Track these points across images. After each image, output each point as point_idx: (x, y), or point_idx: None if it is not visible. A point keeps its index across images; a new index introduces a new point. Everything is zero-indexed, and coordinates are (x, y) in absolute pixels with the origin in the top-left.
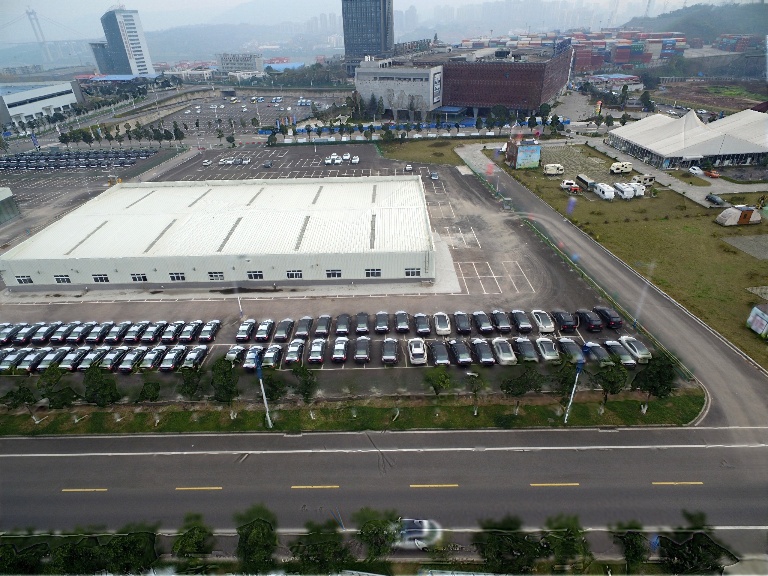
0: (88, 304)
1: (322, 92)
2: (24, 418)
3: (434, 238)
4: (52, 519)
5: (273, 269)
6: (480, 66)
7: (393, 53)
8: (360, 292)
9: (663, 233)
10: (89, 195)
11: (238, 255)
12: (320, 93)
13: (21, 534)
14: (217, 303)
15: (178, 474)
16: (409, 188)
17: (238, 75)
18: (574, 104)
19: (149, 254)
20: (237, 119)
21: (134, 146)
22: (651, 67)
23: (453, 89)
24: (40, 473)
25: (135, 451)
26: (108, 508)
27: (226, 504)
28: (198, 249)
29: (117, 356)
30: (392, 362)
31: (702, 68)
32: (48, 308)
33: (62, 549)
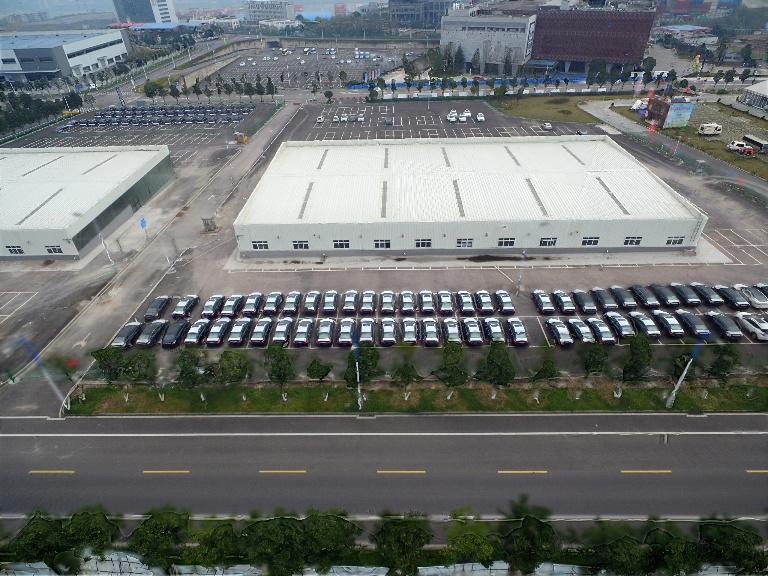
0: (338, 272)
1: (376, 43)
2: (387, 394)
3: None
4: (514, 502)
5: (528, 236)
6: (579, 15)
7: (441, 1)
8: (622, 261)
9: None
10: (224, 154)
11: (495, 221)
12: (374, 44)
13: (494, 518)
14: (478, 272)
15: (610, 456)
16: (604, 149)
17: (270, 24)
18: (663, 58)
19: (390, 219)
20: (300, 72)
21: (221, 101)
22: (713, 18)
23: (545, 41)
24: (458, 453)
25: (538, 430)
26: (566, 491)
27: (692, 489)
28: (438, 214)
29: (436, 329)
30: (739, 338)
31: (764, 19)
32: (299, 276)
33: (681, 545)
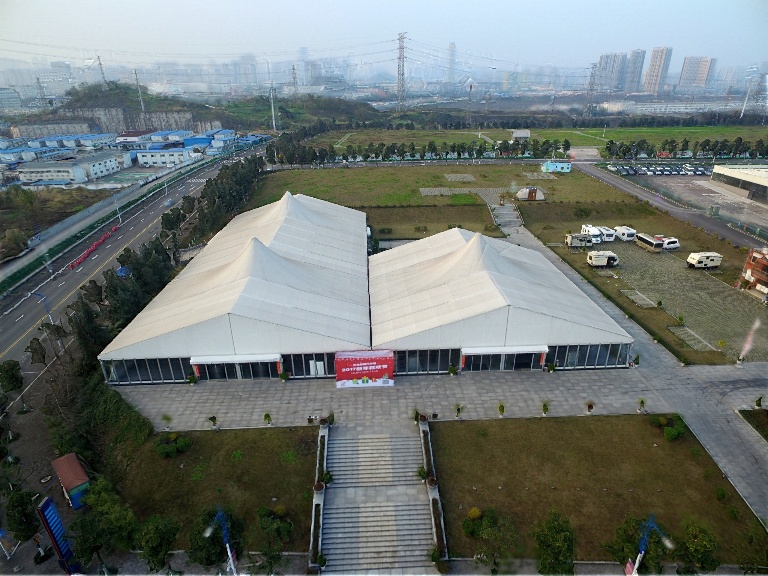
0: None
1: None
2: None
3: (744, 199)
4: None
5: None
6: None
7: None
8: None
9: (584, 196)
10: None
11: None
12: None
13: None
14: None
15: None
16: None
17: None
18: None
19: None
20: None
21: None
22: None
23: None
24: None
25: None
26: None
27: None
28: None
29: None
30: None
31: None
32: None
33: None
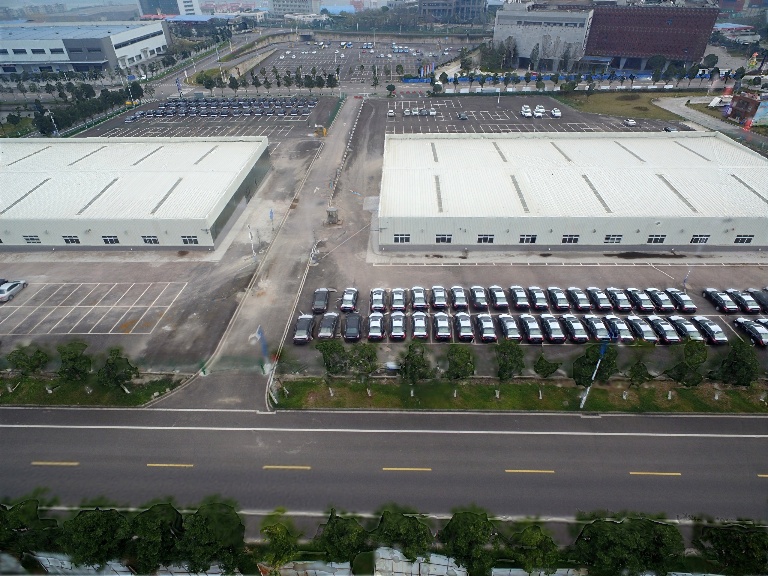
0: (487, 266)
1: (412, 38)
2: (603, 393)
3: None
4: None
5: (680, 233)
6: (639, 11)
7: None
8: None
9: None
10: (309, 146)
11: (650, 217)
12: (410, 39)
13: None
14: (633, 269)
15: None
16: (721, 145)
17: (296, 18)
18: None
19: (534, 213)
20: (343, 66)
21: None
22: (748, 16)
23: (601, 36)
24: (706, 455)
25: None
26: None
27: None
28: (583, 209)
29: None
30: None
31: None
32: (449, 270)
33: None
